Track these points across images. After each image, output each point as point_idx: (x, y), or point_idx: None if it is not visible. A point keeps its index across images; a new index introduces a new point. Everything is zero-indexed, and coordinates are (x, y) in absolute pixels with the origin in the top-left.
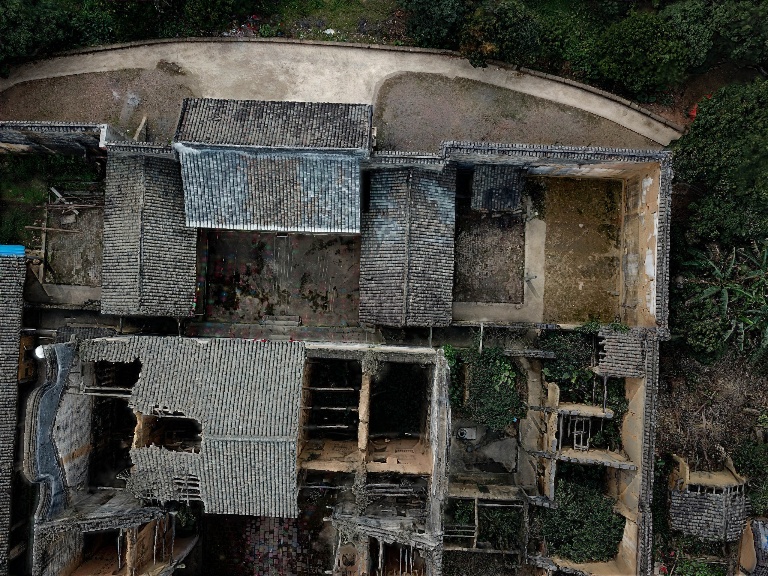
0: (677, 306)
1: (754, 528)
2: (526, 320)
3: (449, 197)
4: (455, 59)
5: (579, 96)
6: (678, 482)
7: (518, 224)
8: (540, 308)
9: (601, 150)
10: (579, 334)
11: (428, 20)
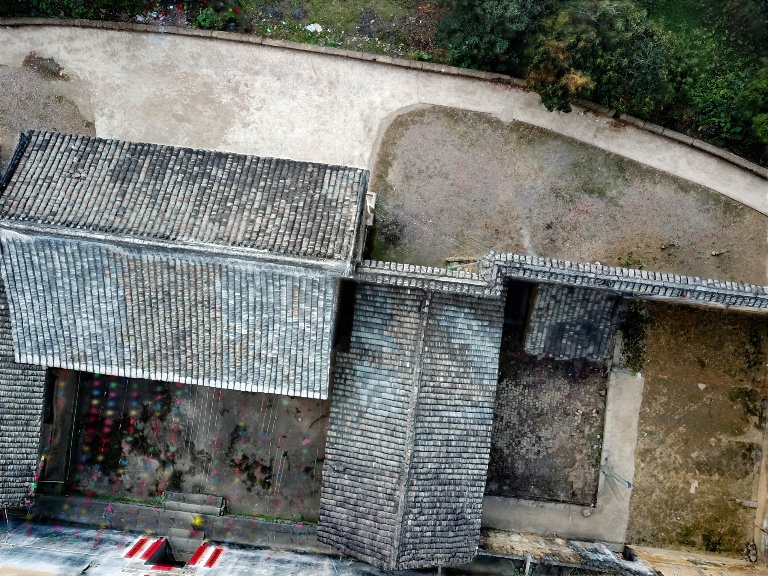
0: None
1: None
2: (598, 536)
3: (491, 337)
4: (514, 91)
5: (713, 168)
6: None
7: (597, 374)
8: (623, 518)
9: None
10: None
11: (478, 23)
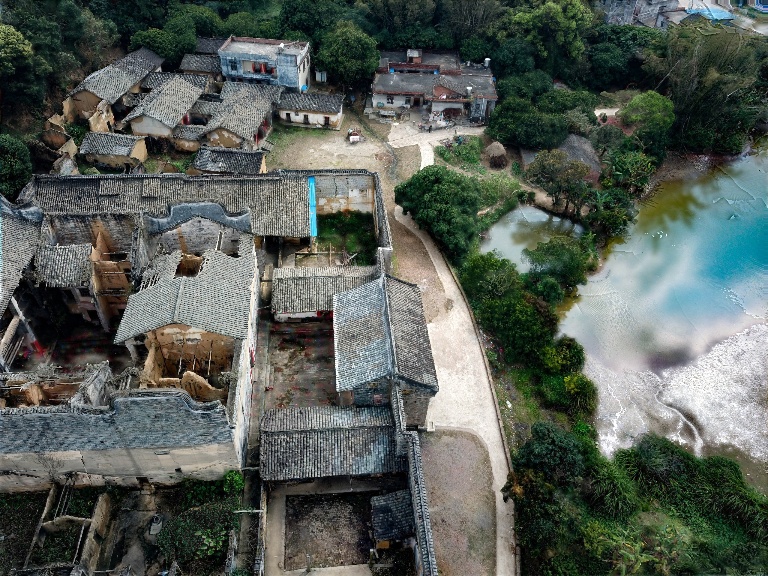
0: None
1: None
2: (267, 575)
3: (377, 466)
4: None
5: None
6: None
7: (365, 558)
8: None
9: (434, 570)
10: None
11: None
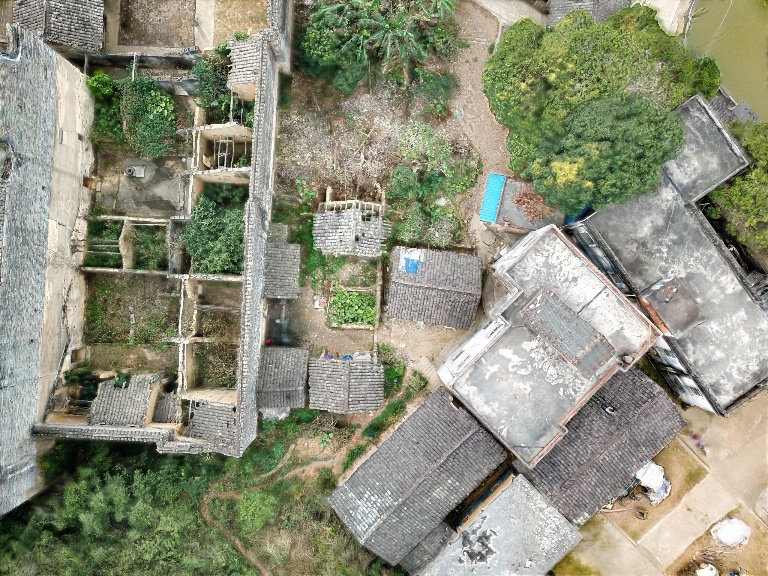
0: (307, 24)
1: (395, 251)
2: None
3: None
4: None
5: None
6: (319, 204)
7: None
8: None
9: None
10: (219, 55)
11: None
